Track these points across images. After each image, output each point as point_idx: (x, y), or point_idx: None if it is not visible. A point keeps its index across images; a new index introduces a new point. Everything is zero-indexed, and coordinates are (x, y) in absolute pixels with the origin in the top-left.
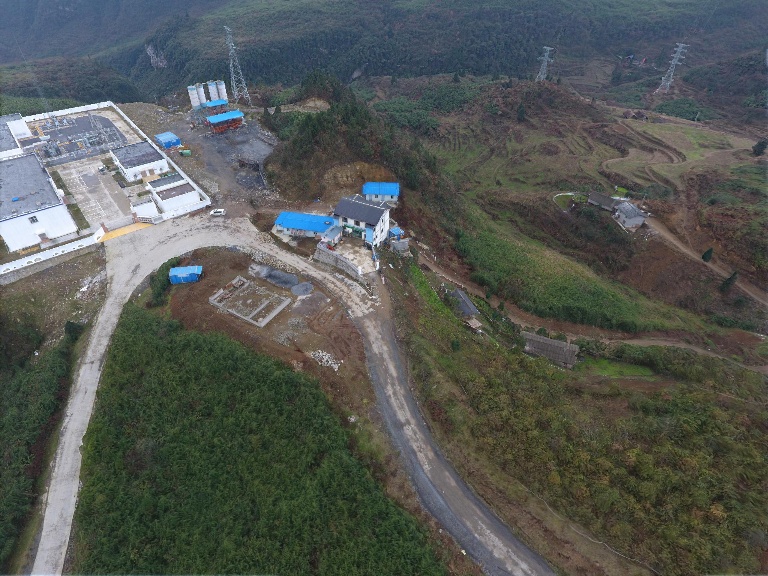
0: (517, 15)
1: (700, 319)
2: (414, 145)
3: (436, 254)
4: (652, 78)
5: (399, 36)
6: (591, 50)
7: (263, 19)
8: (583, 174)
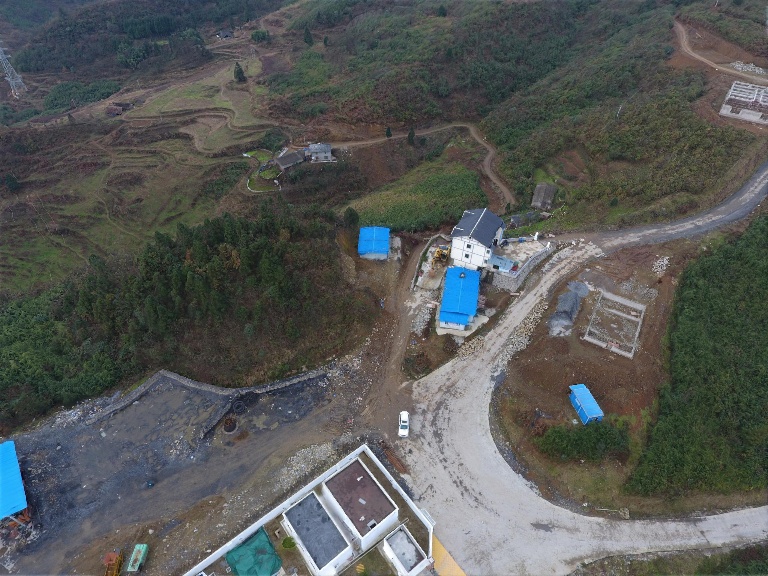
0: None
1: (430, 162)
2: None
3: None
4: None
5: None
6: None
7: None
8: (207, 168)
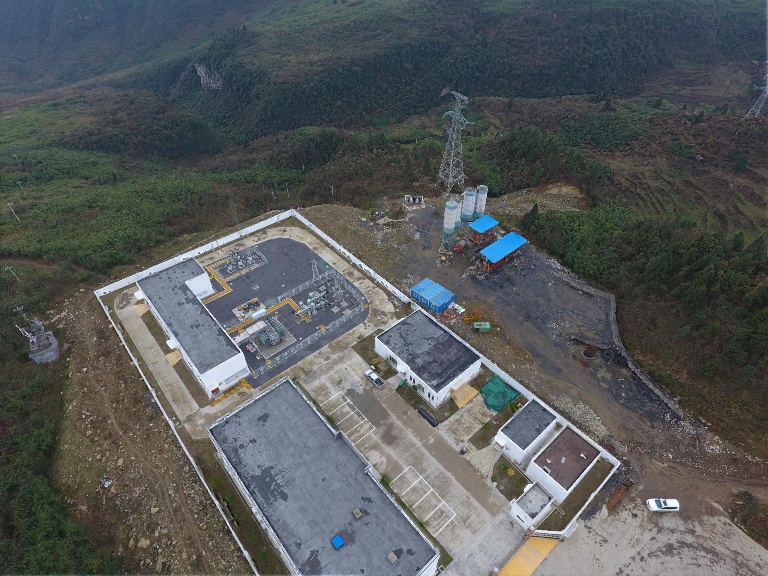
0: (633, 16)
1: None
2: None
3: None
4: None
5: (494, 45)
6: (717, 54)
7: (337, 31)
8: None
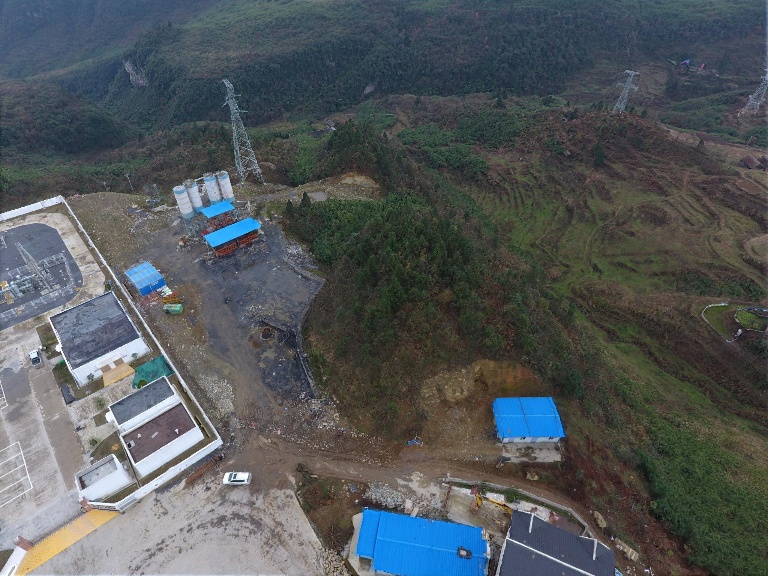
0: (553, 16)
1: None
2: (531, 277)
3: (643, 553)
4: (730, 93)
5: (417, 44)
6: (638, 54)
7: (259, 28)
8: (721, 263)
